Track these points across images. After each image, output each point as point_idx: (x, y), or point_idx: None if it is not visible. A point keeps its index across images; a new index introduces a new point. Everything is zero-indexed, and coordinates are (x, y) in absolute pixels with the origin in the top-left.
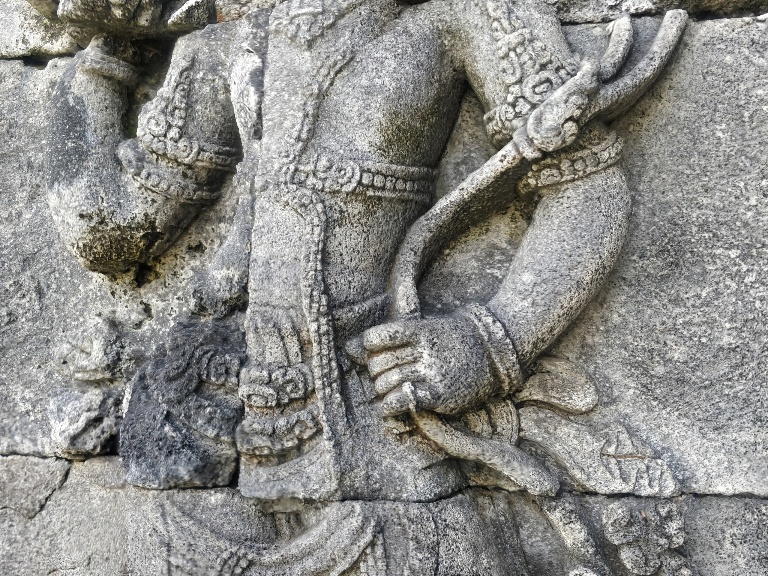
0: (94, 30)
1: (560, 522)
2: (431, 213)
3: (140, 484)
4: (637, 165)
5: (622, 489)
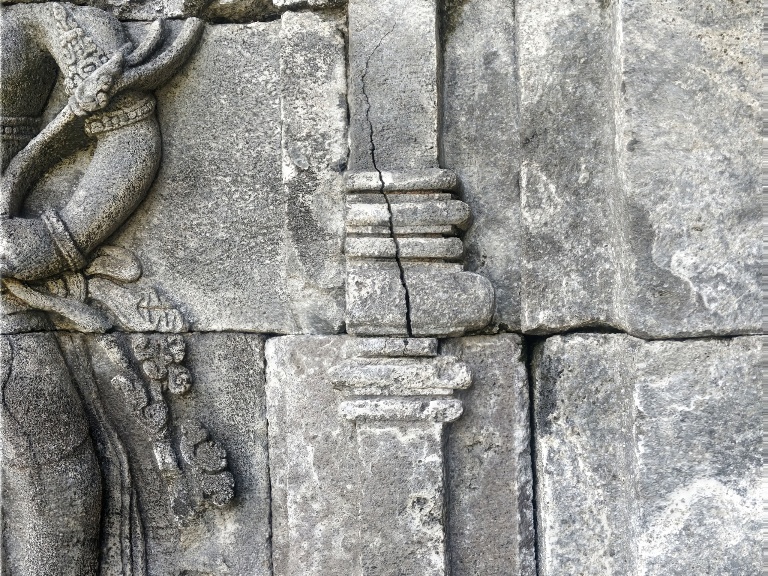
0: None
1: (105, 348)
2: (25, 149)
3: None
4: (172, 120)
5: (150, 328)
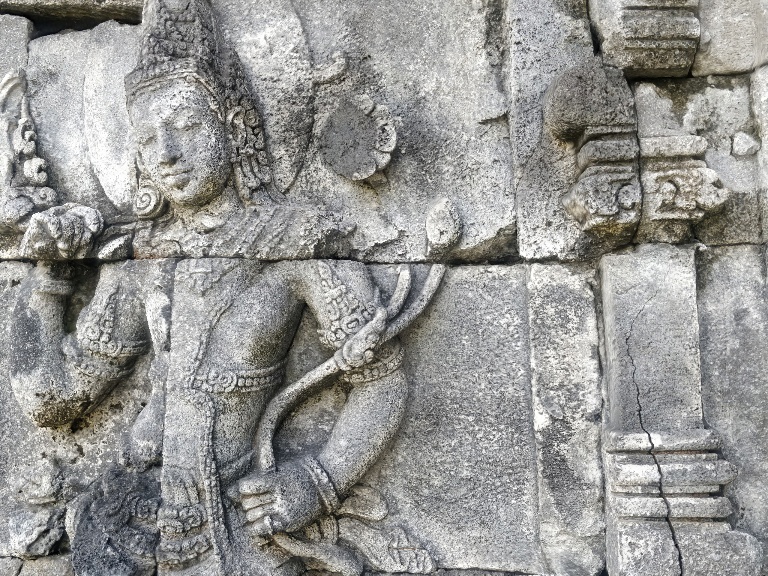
0: (43, 259)
1: None
2: (282, 396)
3: None
4: (414, 360)
5: (401, 570)
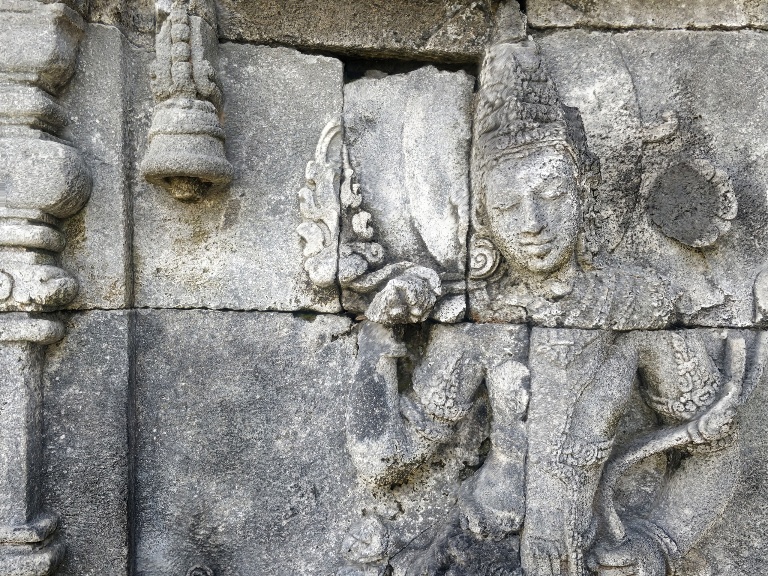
0: None
1: None
2: (622, 463)
3: None
4: None
5: None
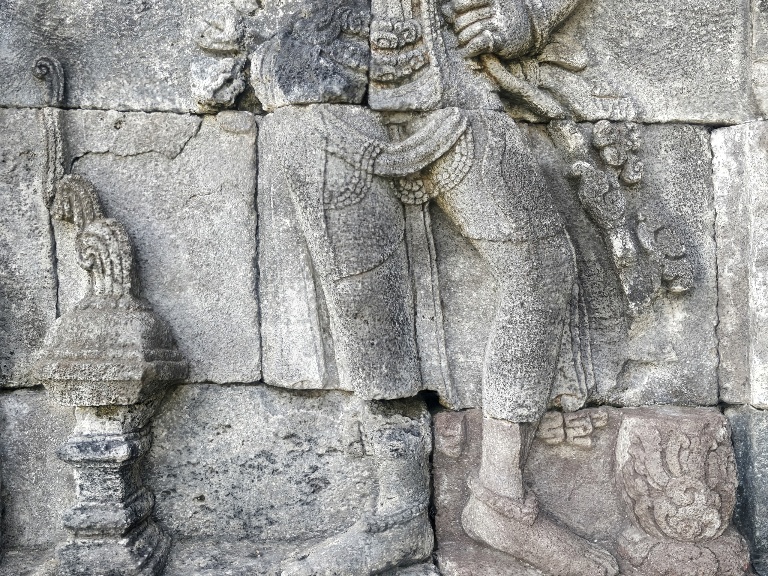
0: None
1: (569, 133)
2: None
3: (302, 100)
4: None
5: (604, 116)
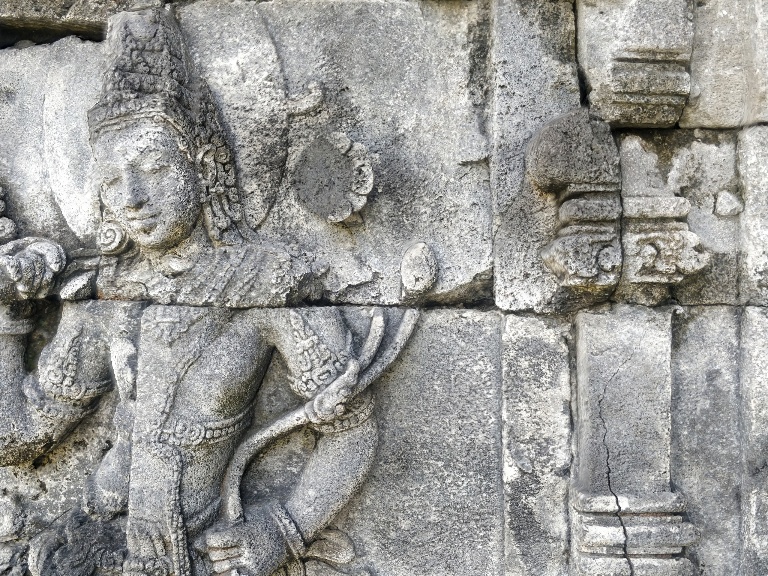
0: None
1: None
2: (251, 443)
3: None
4: (385, 403)
5: None
